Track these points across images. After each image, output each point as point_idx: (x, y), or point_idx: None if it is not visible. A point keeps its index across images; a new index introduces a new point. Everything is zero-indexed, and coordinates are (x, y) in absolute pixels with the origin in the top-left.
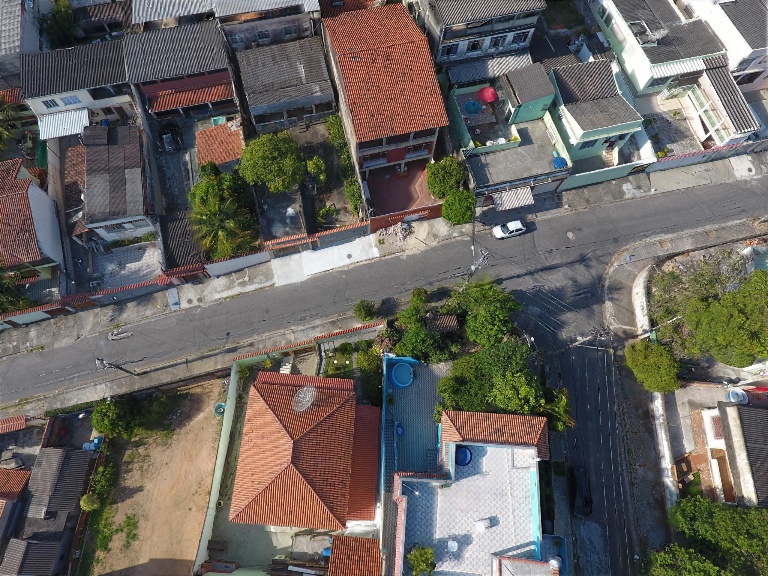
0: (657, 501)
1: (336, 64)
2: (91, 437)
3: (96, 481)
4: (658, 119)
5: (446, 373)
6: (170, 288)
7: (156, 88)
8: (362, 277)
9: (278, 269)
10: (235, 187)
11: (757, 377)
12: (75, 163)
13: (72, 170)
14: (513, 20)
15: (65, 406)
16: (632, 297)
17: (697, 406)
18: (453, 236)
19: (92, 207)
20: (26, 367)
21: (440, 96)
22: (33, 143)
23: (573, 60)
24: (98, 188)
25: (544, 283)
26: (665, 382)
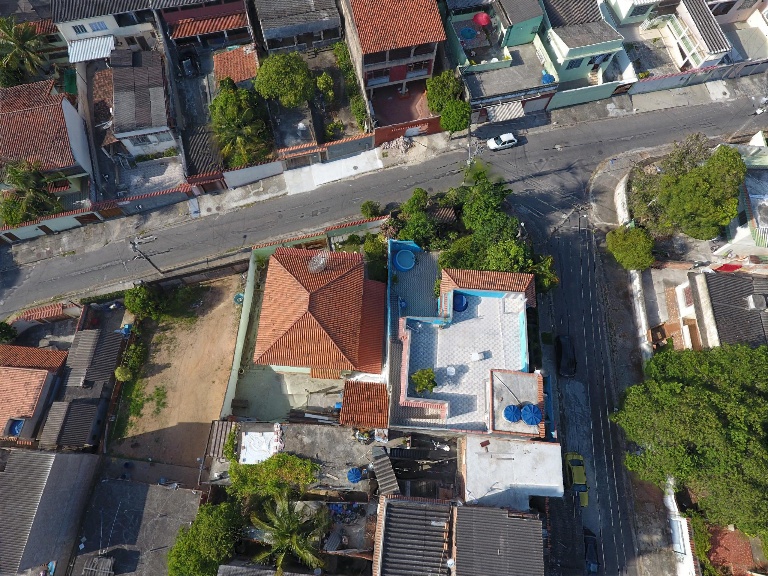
0: (635, 364)
1: None
2: (121, 325)
3: (128, 357)
4: (640, 47)
5: None
6: (191, 199)
7: (176, 16)
8: (367, 185)
9: (290, 180)
10: (251, 101)
11: (726, 260)
12: (102, 85)
13: (100, 91)
14: None
15: None
16: (614, 199)
17: (671, 284)
18: (451, 149)
19: (120, 119)
20: (59, 269)
21: (438, 14)
22: (60, 75)
23: None
24: (125, 103)
25: (534, 187)
26: (641, 258)
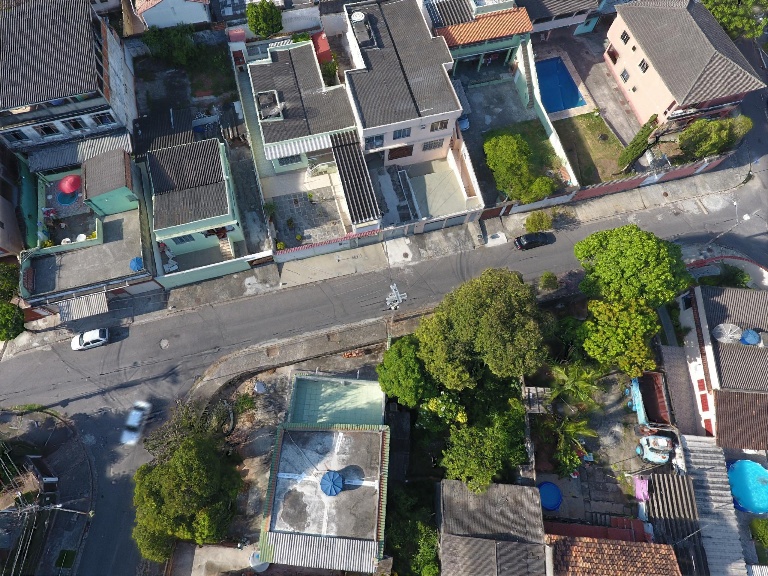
0: None
1: None
2: None
3: None
4: (300, 200)
5: None
6: None
7: None
8: None
9: None
10: None
11: None
12: None
13: None
14: (72, 103)
15: None
16: None
17: (214, 570)
18: (32, 346)
19: None
20: None
21: None
22: None
23: (189, 138)
24: None
25: (112, 405)
26: (149, 552)
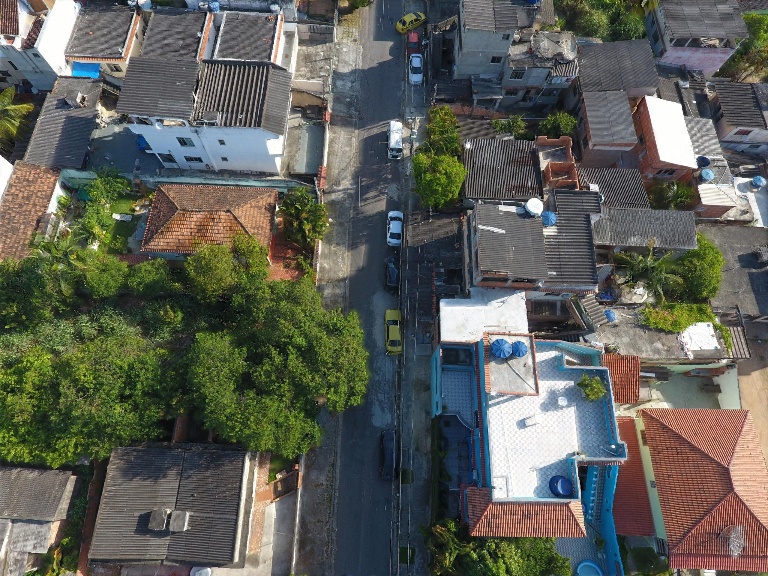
0: (313, 450)
1: None
2: None
3: None
4: None
5: None
6: None
7: None
8: None
9: None
10: None
11: None
12: None
13: None
14: None
15: None
16: None
17: (250, 560)
18: None
19: None
20: None
21: None
22: None
23: None
24: None
25: None
26: None
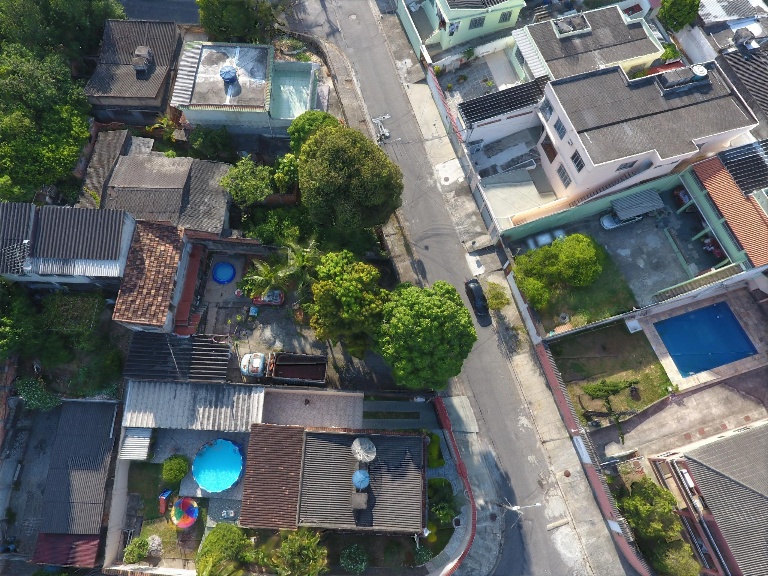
0: None
1: None
2: None
3: None
4: None
5: None
6: None
7: None
8: None
9: None
10: None
11: None
12: None
13: None
14: None
15: None
16: None
17: None
18: None
19: None
20: None
21: None
22: None
23: None
24: None
25: None
26: None
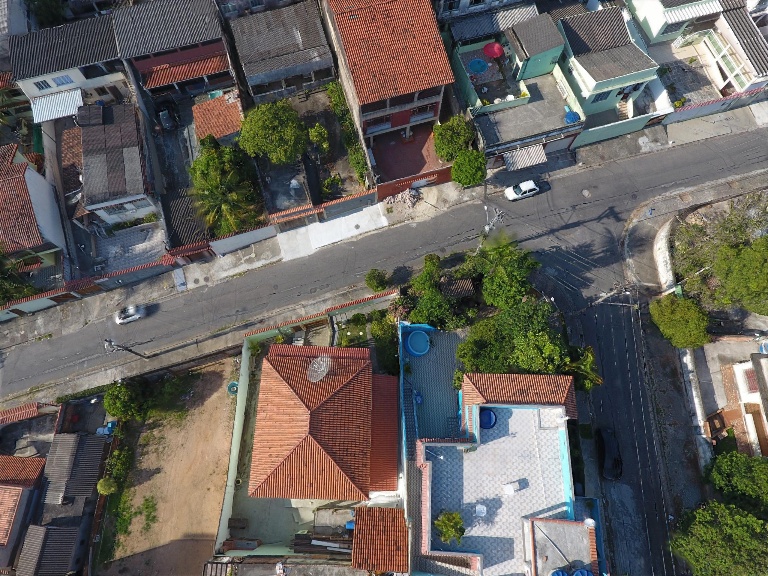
0: (690, 460)
1: (334, 25)
2: (104, 422)
3: (112, 465)
4: (673, 68)
5: (464, 339)
6: (176, 269)
7: (149, 63)
8: (371, 247)
9: (285, 244)
10: (236, 160)
11: None
12: (71, 145)
13: (69, 153)
14: None
15: (76, 392)
16: (654, 253)
17: (728, 361)
18: (464, 200)
19: (91, 188)
20: (35, 355)
21: (444, 52)
22: (28, 130)
23: (581, 10)
24: (96, 169)
25: (561, 243)
26: (694, 336)
